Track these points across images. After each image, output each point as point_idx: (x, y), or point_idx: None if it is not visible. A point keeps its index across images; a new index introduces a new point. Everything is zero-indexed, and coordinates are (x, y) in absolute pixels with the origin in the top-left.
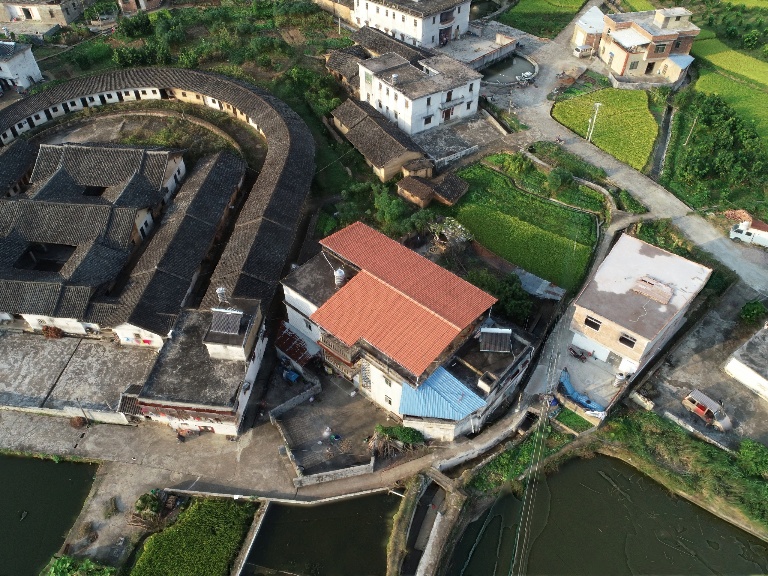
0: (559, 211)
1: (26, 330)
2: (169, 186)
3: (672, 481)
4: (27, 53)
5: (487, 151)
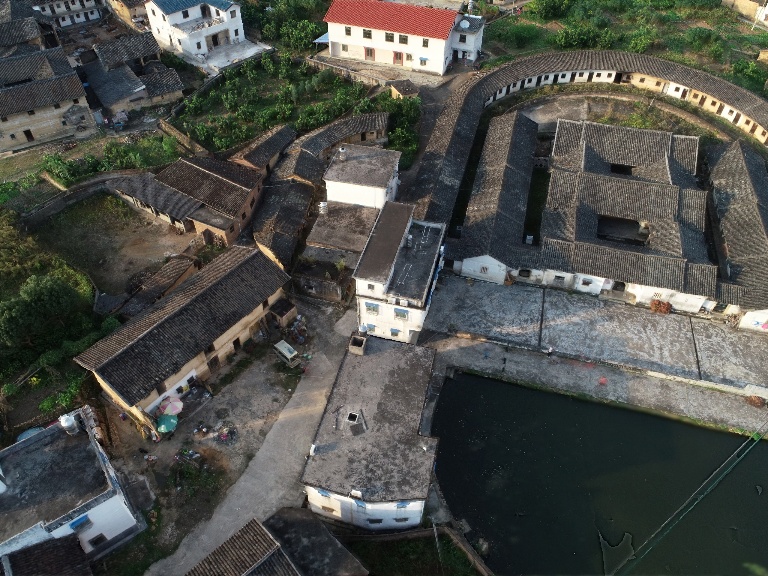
0: None
1: (627, 302)
2: None
3: None
4: (482, 27)
5: None
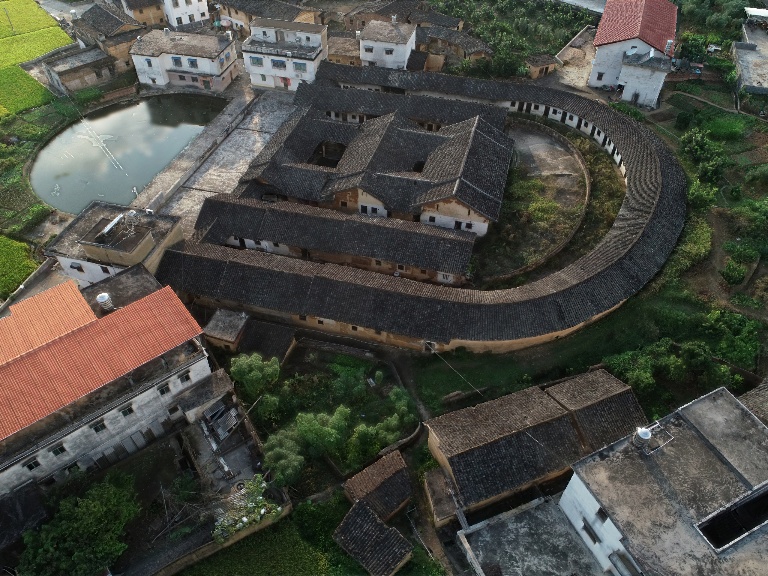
0: None
1: None
2: (440, 220)
3: None
4: (658, 74)
5: None
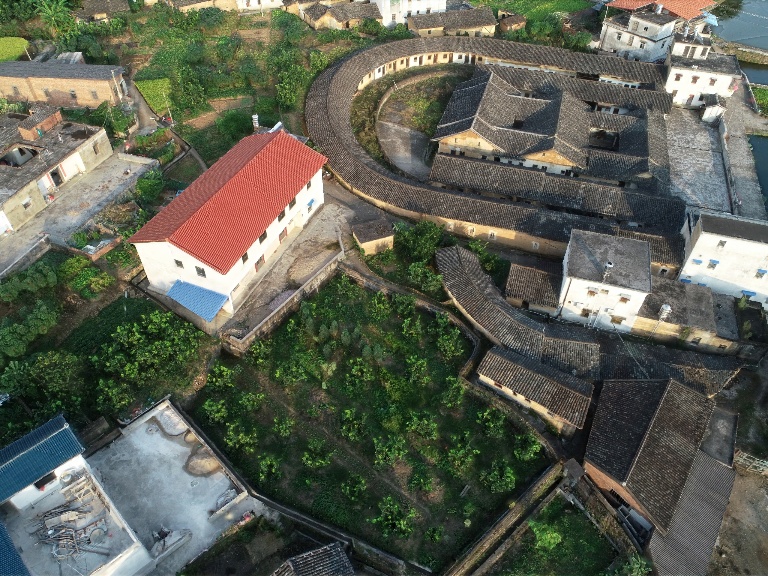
0: None
1: None
2: None
3: None
4: None
5: (468, 2)
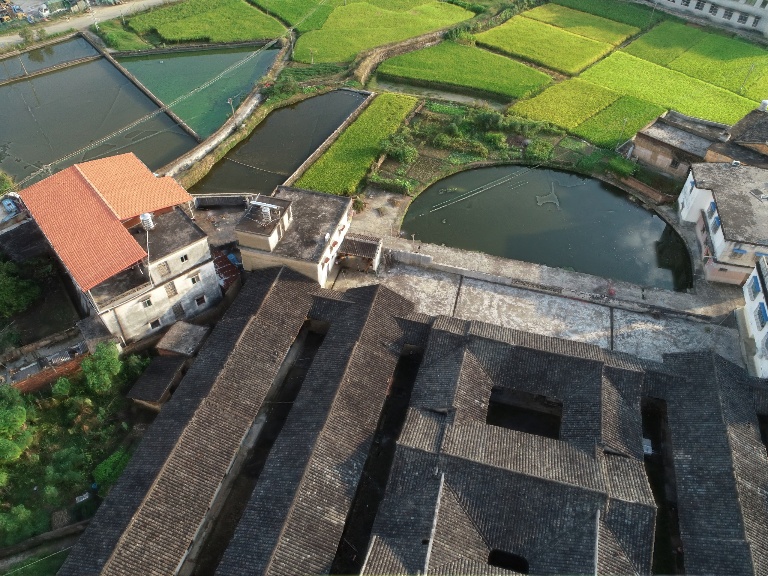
0: None
1: None
2: None
3: (6, 176)
4: None
5: None
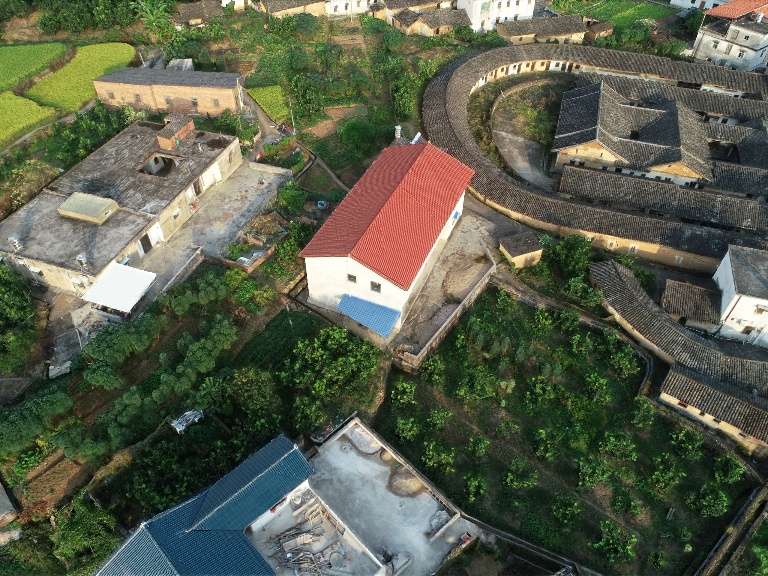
0: (608, 5)
1: None
2: None
3: None
4: None
5: None
